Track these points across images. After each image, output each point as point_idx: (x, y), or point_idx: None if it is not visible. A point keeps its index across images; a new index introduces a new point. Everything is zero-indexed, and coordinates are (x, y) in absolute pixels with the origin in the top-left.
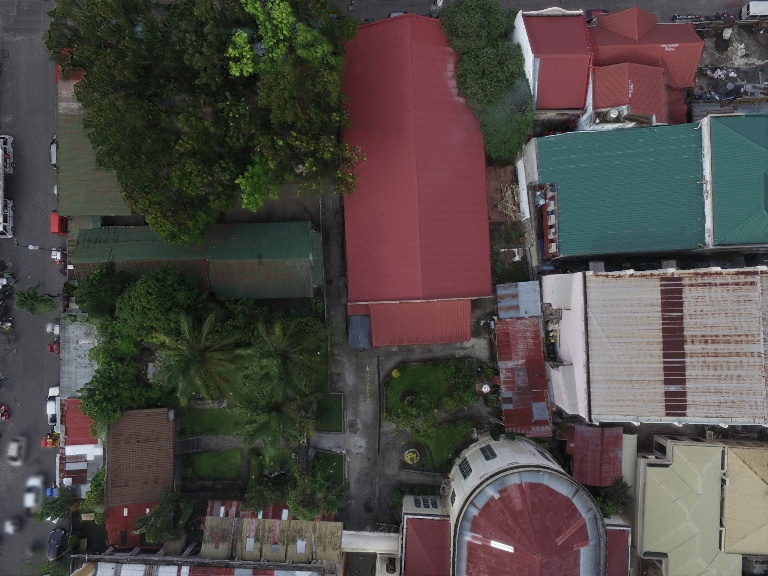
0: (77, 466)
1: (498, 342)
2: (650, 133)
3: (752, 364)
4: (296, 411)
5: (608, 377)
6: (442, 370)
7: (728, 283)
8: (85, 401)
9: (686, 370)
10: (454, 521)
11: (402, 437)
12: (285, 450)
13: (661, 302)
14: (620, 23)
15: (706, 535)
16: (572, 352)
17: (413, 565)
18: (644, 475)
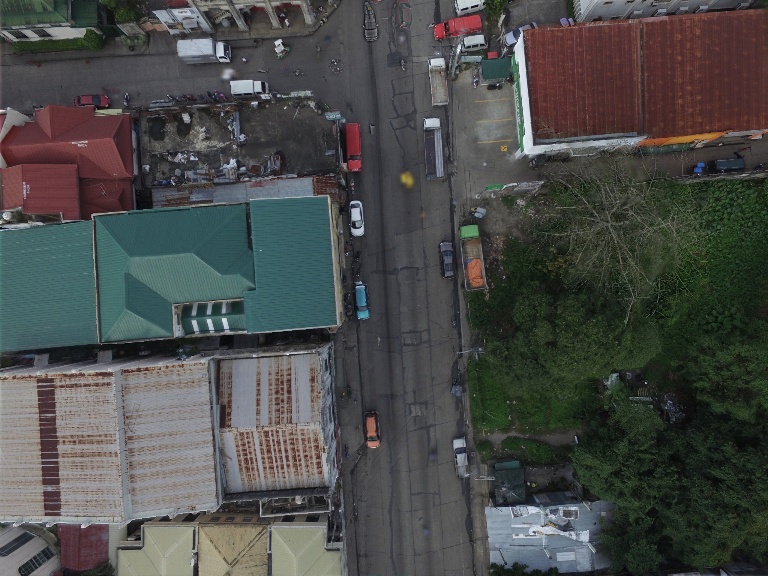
0: None
1: None
2: (60, 230)
3: (110, 464)
4: None
5: None
6: None
7: (90, 384)
8: None
9: (59, 470)
10: None
11: None
12: None
13: (38, 403)
14: (44, 120)
15: None
16: None
17: None
18: (115, 558)
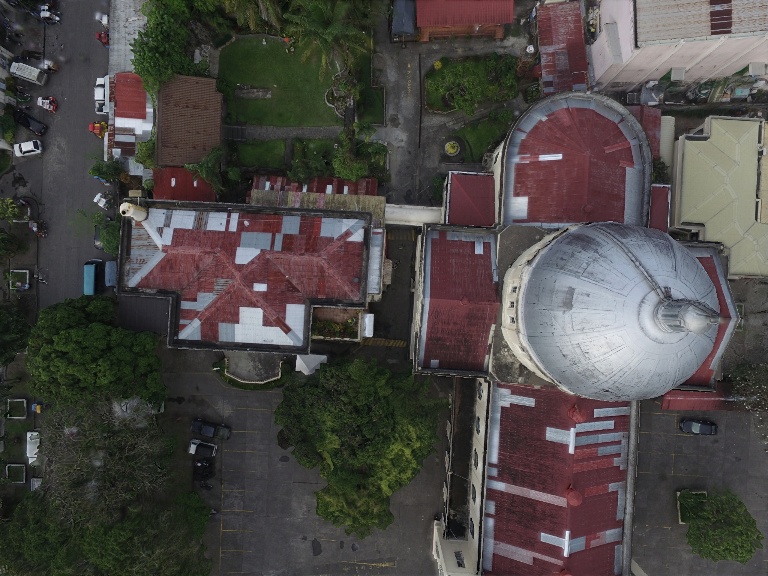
0: (126, 139)
1: (539, 28)
2: None
3: None
4: (343, 77)
5: (654, 4)
6: (482, 67)
7: None
8: (139, 46)
9: None
10: (500, 157)
11: (442, 132)
12: (328, 141)
13: None
14: None
15: (743, 203)
16: (615, 12)
17: (457, 216)
18: (683, 147)
